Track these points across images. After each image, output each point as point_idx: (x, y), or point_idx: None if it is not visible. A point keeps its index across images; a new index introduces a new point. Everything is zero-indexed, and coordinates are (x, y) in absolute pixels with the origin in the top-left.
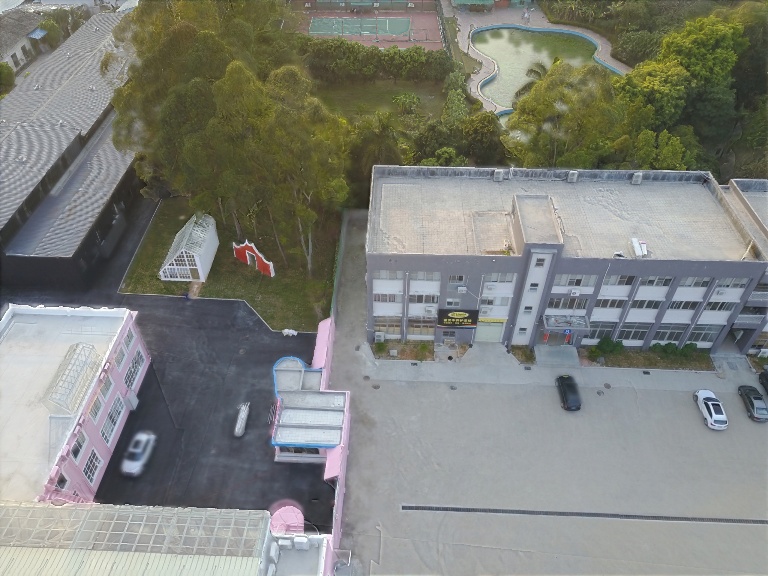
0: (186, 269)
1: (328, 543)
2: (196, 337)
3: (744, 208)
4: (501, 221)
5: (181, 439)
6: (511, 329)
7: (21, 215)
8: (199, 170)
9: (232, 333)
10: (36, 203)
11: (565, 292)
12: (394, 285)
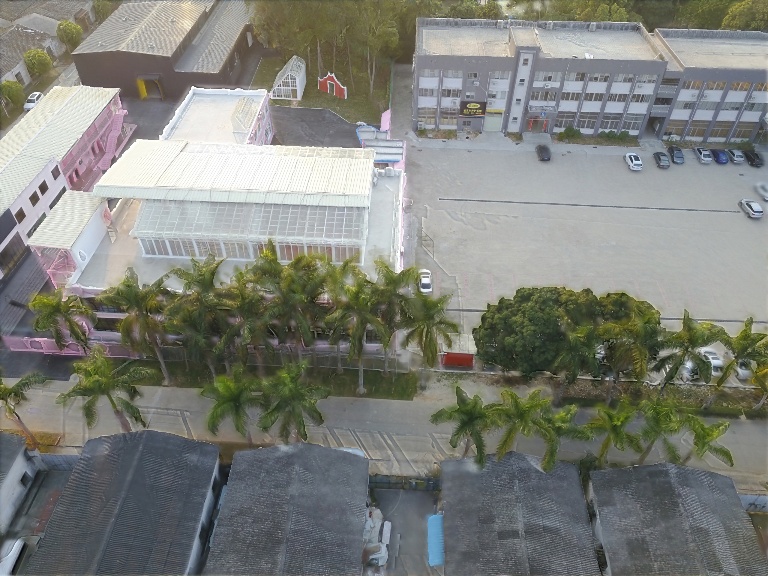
0: (289, 89)
1: (404, 175)
2: (300, 125)
3: (661, 43)
4: (502, 46)
5: None
6: (507, 117)
7: (180, 50)
8: (311, 5)
9: (324, 124)
10: (186, 47)
11: (542, 86)
12: (433, 82)
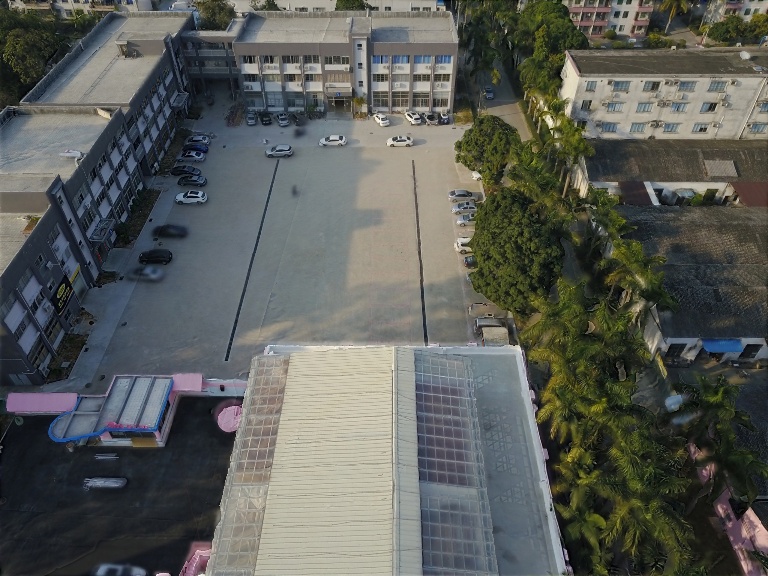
0: None
1: None
2: None
3: None
4: None
5: (112, 541)
6: (87, 269)
7: None
8: None
9: None
10: None
11: (83, 211)
12: (16, 312)
